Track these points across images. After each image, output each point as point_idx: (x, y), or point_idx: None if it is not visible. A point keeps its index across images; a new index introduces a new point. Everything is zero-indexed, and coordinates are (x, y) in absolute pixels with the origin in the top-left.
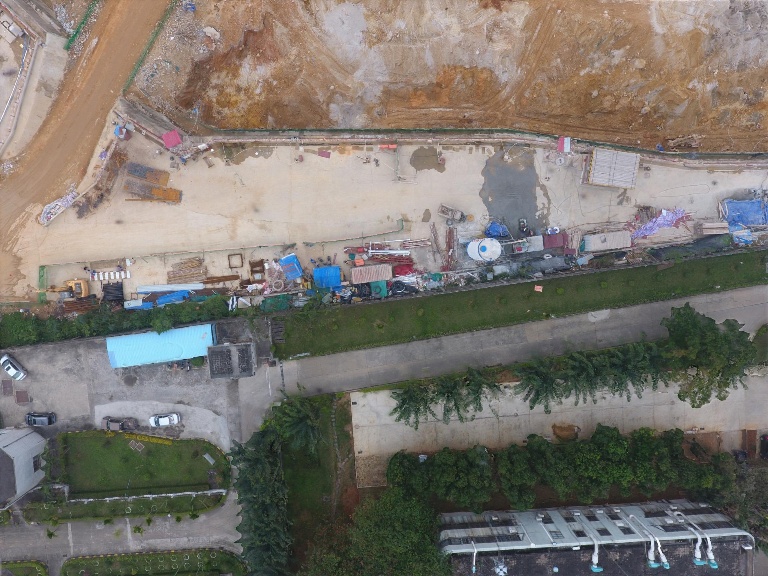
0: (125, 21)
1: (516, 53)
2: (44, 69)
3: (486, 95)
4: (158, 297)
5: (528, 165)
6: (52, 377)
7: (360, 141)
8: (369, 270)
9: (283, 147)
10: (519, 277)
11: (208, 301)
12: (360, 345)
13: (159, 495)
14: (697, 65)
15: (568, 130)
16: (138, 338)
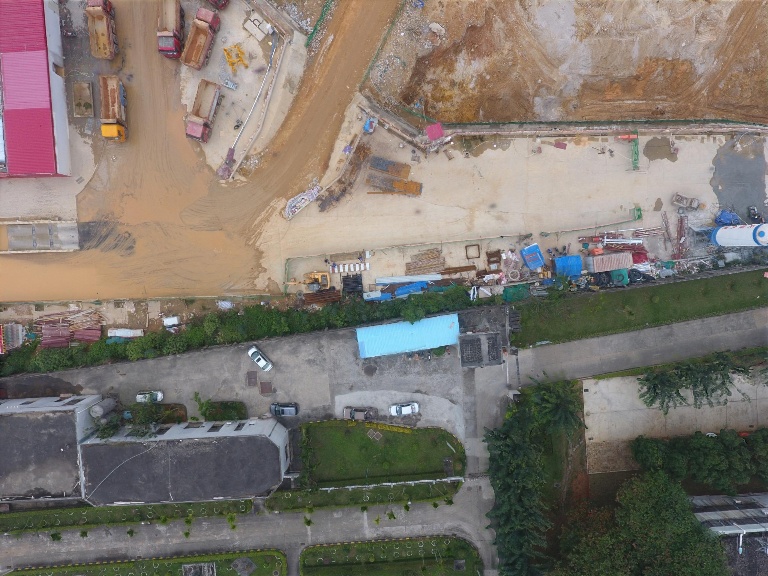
0: (359, 18)
1: (717, 45)
2: (290, 66)
3: (681, 87)
4: (397, 288)
5: (758, 154)
6: (295, 368)
7: (596, 132)
8: (610, 259)
9: (521, 139)
10: (751, 264)
11: (451, 291)
12: (594, 333)
13: (398, 483)
14: None
15: (752, 120)
16: (387, 328)
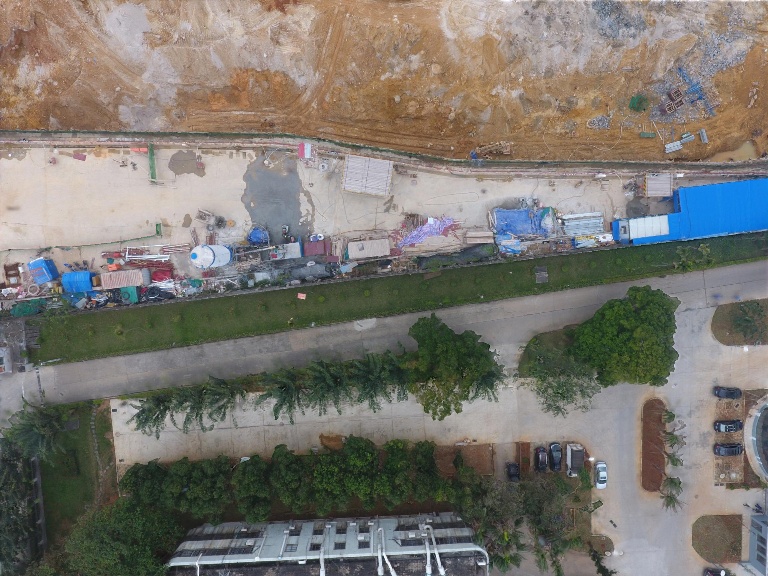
0: None
1: (309, 57)
2: None
3: (286, 99)
4: None
5: (291, 171)
6: None
7: (116, 144)
8: (119, 275)
9: (37, 149)
10: None
11: None
12: (118, 351)
13: None
14: (498, 71)
15: (379, 135)
16: None
